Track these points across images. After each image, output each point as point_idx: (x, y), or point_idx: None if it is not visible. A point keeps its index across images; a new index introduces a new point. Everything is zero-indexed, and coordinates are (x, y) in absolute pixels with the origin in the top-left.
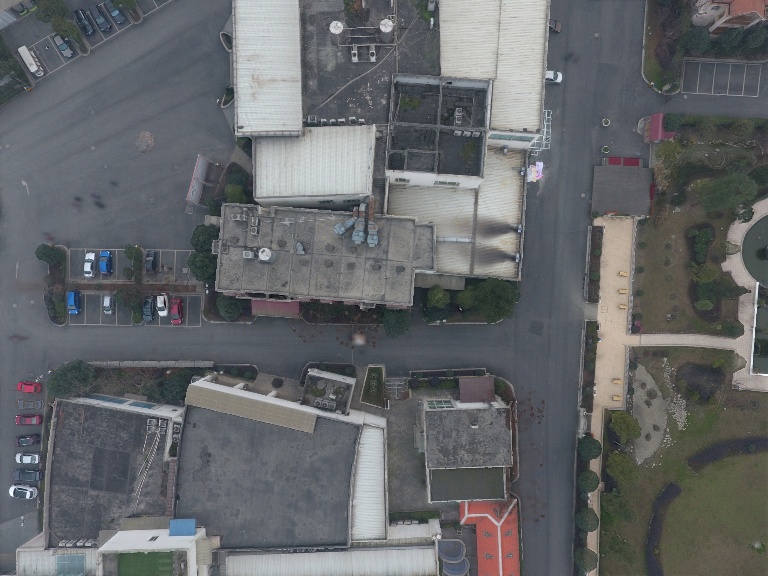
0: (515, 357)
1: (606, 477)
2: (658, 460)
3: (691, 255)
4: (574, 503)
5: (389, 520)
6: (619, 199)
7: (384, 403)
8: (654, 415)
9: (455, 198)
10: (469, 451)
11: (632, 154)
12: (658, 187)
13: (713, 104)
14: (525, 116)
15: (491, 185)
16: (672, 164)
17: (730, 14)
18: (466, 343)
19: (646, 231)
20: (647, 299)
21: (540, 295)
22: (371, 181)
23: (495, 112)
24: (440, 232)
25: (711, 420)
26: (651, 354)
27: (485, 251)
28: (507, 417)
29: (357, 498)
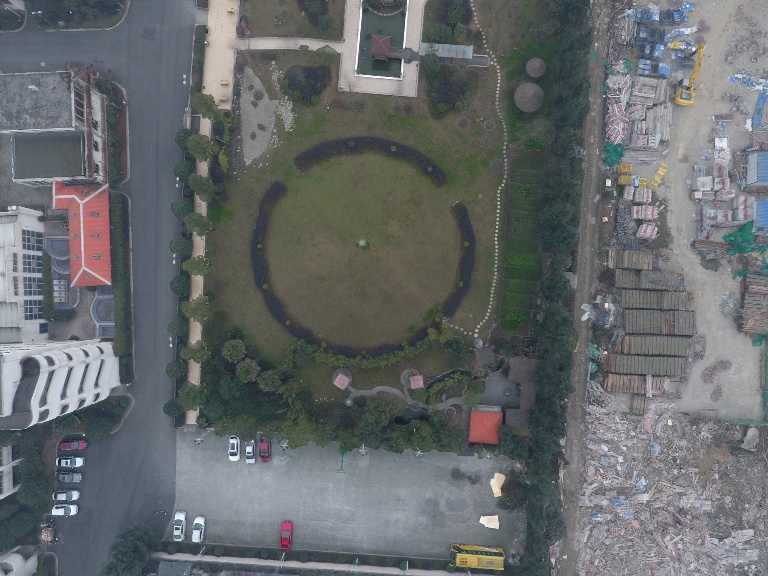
0: (128, 62)
1: (209, 173)
2: (265, 160)
3: None
4: None
5: None
6: None
7: None
8: (259, 115)
9: None
10: (32, 115)
11: None
12: None
13: None
14: None
15: None
16: None
17: None
18: (80, 49)
19: None
20: (257, 5)
21: (153, 2)
22: None
23: None
24: None
25: (317, 121)
26: (258, 57)
27: None
28: (69, 81)
29: None
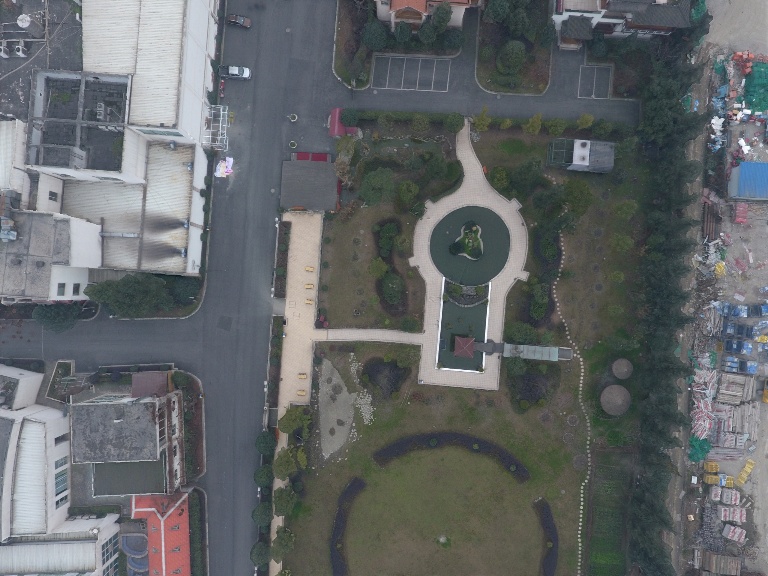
0: (203, 352)
1: None
2: (344, 454)
3: (377, 250)
4: (260, 497)
5: (69, 515)
6: (307, 194)
7: (66, 398)
8: (338, 410)
9: (125, 193)
10: (116, 445)
11: (322, 149)
12: (347, 182)
13: (403, 99)
14: (162, 111)
15: (160, 180)
16: (361, 159)
17: (391, 9)
18: (155, 338)
19: (334, 226)
20: (335, 294)
21: (229, 290)
22: (18, 176)
23: (134, 107)
24: (110, 227)
25: (397, 415)
26: (337, 349)
27: (153, 246)
28: (154, 411)
29: (18, 493)
